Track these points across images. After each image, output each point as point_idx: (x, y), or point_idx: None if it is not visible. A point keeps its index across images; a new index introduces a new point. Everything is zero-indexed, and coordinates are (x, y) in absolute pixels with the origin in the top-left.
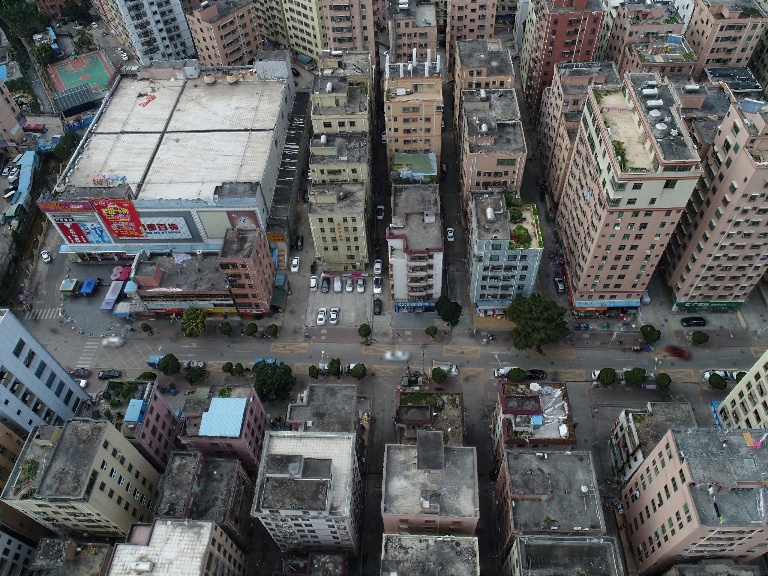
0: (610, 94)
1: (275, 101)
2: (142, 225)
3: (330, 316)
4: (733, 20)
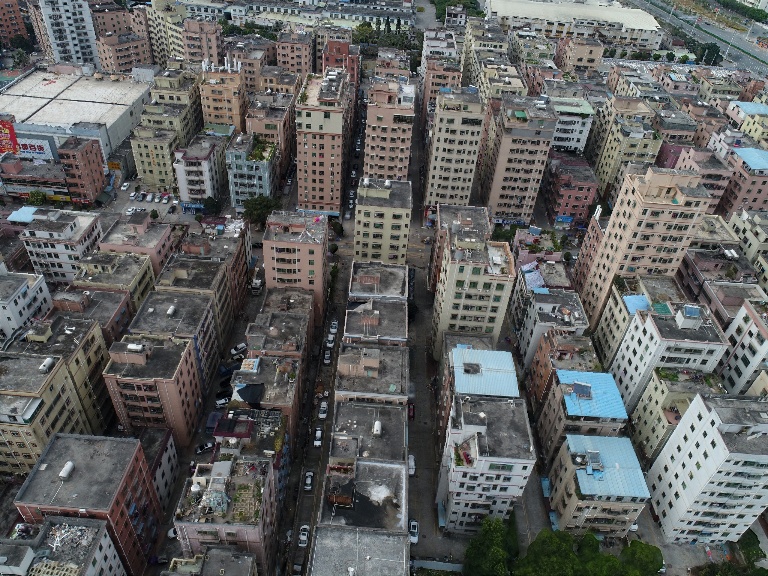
0: (319, 79)
1: (140, 92)
2: (18, 144)
3: None
4: (439, 72)
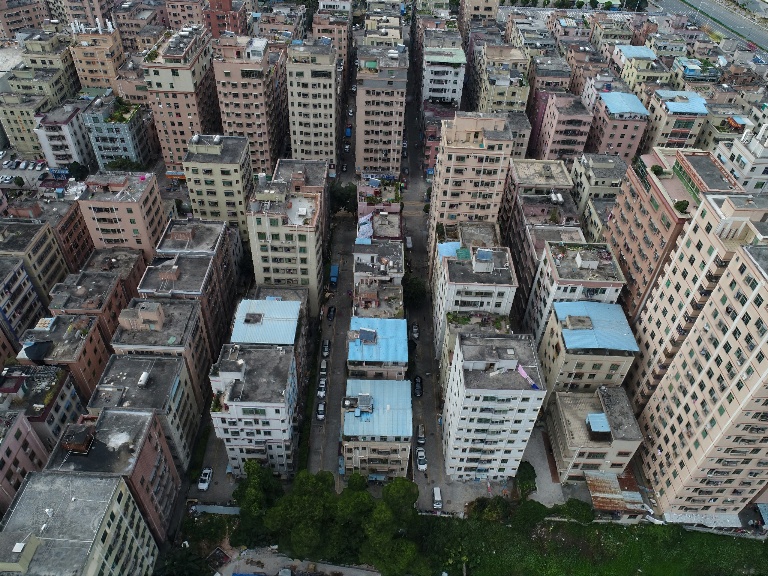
0: None
1: None
2: None
3: (6, 178)
4: (324, 26)
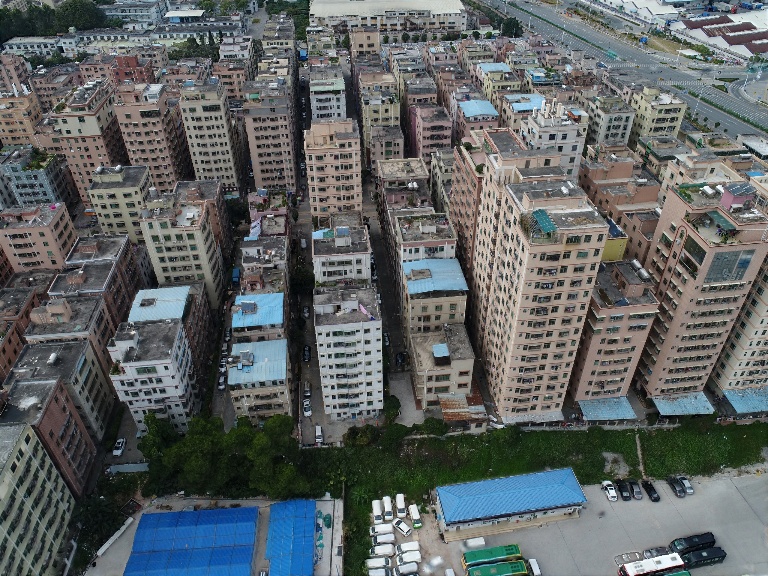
0: None
1: None
2: None
3: None
4: (223, 72)
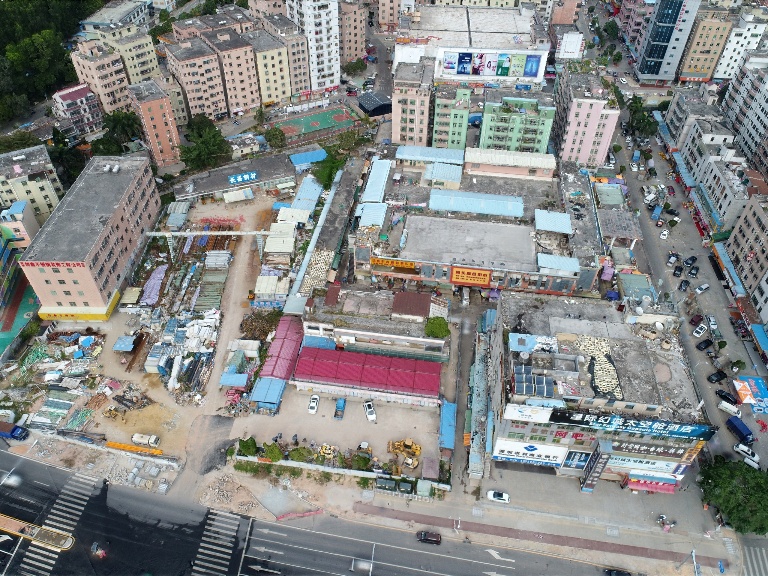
0: None
1: (438, 8)
2: None
3: None
4: None
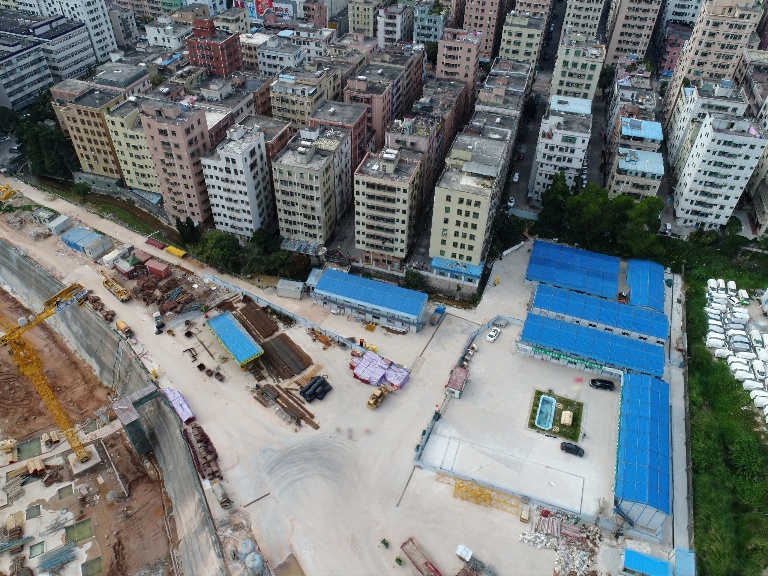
0: None
1: None
2: (273, 7)
3: None
4: None
